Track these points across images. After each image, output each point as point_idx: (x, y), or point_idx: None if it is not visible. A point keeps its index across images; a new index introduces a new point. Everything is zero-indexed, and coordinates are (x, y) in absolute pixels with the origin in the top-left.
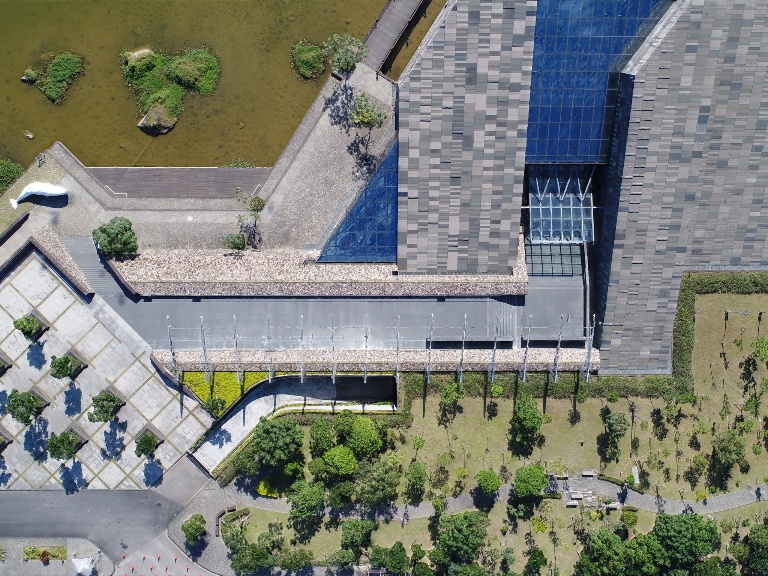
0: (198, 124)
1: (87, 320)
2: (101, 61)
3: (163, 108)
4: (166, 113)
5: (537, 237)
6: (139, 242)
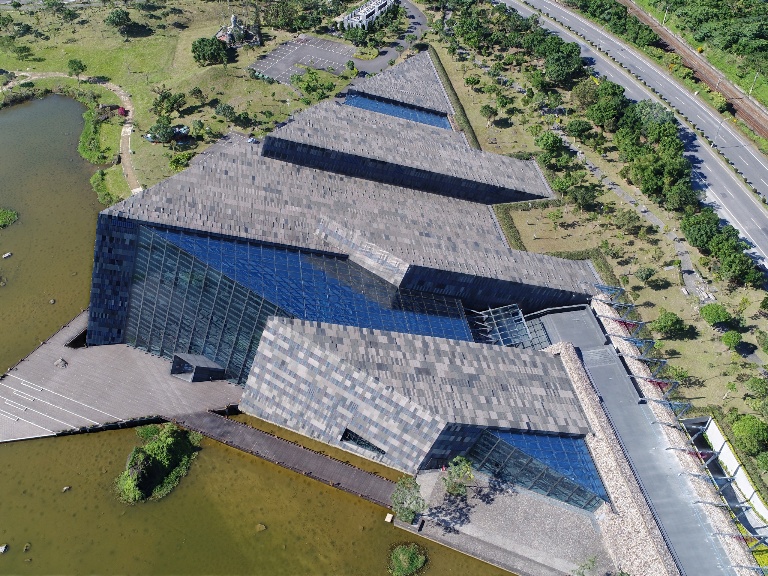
0: None
1: None
2: None
3: None
4: None
5: None
6: None
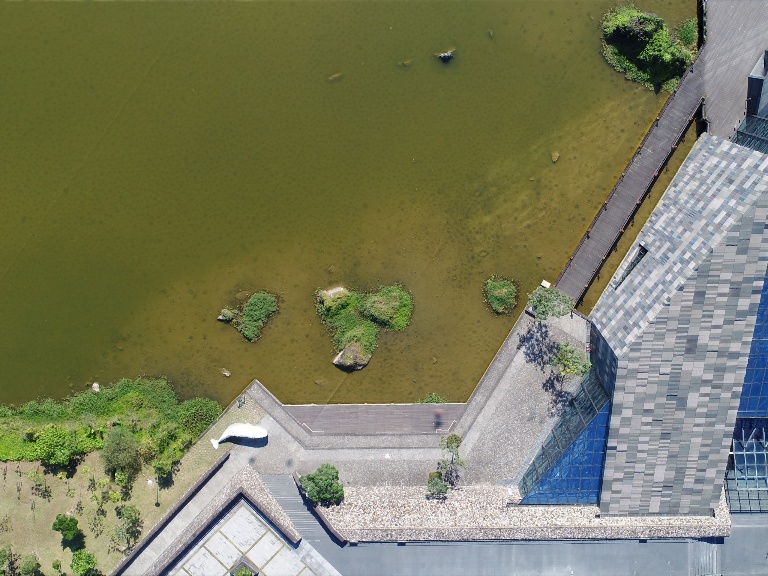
0: (392, 360)
1: (295, 565)
2: (295, 299)
3: (358, 346)
4: (361, 351)
5: (732, 471)
6: (338, 480)
